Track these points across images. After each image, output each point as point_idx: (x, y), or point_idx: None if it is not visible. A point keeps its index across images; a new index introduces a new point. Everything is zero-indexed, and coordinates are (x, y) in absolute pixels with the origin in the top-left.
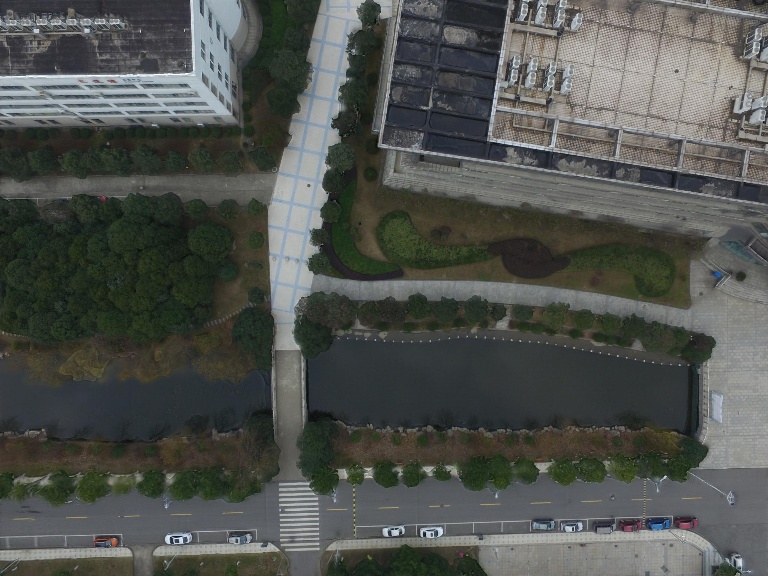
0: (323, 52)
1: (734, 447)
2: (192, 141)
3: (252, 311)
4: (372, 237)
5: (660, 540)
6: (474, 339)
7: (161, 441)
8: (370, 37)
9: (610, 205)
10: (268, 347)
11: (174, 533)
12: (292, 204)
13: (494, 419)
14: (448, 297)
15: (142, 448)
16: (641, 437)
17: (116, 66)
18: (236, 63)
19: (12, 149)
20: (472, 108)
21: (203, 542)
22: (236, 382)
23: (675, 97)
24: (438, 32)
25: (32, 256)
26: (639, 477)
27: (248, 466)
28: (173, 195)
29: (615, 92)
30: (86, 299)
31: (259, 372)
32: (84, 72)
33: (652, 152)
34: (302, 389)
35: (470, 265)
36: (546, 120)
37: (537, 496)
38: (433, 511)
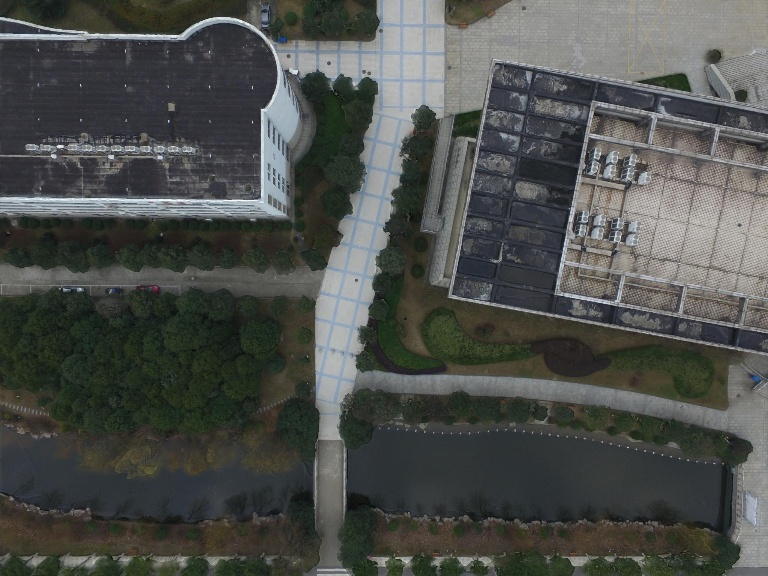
0: (375, 150)
1: (766, 546)
2: (244, 234)
3: (298, 405)
4: (417, 332)
5: None
6: (513, 432)
7: (203, 523)
8: (424, 144)
9: None
10: (313, 441)
11: None
12: (339, 298)
13: (527, 504)
14: (489, 392)
15: (184, 530)
16: (674, 533)
17: (185, 188)
18: (290, 160)
19: (70, 243)
20: (540, 261)
21: None
22: (279, 471)
23: (737, 250)
24: (510, 187)
25: (88, 350)
26: None
27: (290, 557)
28: (227, 294)
29: (678, 244)
30: (140, 395)
31: (302, 462)
32: (154, 194)
33: (712, 302)
34: (344, 480)
35: (512, 362)
36: None
37: None
38: None
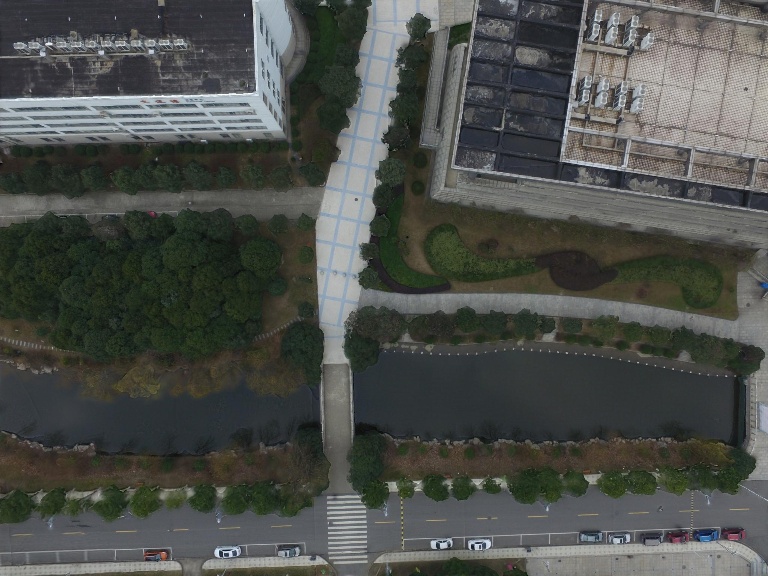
0: (370, 66)
1: None
2: (240, 156)
3: (302, 325)
4: (419, 250)
5: (708, 551)
6: (520, 351)
7: (209, 455)
8: (420, 52)
9: (661, 218)
10: (318, 361)
11: (223, 546)
12: (340, 218)
13: (537, 430)
14: (495, 310)
15: (190, 462)
16: (688, 448)
17: (178, 86)
18: (284, 78)
19: (64, 166)
20: (544, 128)
21: (252, 555)
22: (285, 396)
23: (744, 115)
24: (510, 53)
25: (86, 273)
26: (689, 489)
27: (299, 480)
28: (225, 211)
29: (684, 111)
30: (140, 315)
31: (308, 386)
32: (147, 92)
33: (721, 170)
34: (351, 403)
35: (517, 278)
36: (616, 139)
37: (584, 508)
38: (481, 523)
